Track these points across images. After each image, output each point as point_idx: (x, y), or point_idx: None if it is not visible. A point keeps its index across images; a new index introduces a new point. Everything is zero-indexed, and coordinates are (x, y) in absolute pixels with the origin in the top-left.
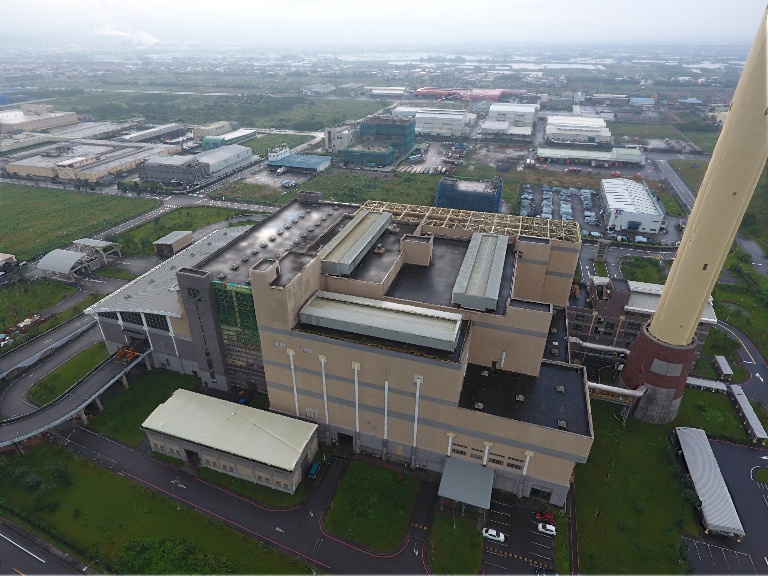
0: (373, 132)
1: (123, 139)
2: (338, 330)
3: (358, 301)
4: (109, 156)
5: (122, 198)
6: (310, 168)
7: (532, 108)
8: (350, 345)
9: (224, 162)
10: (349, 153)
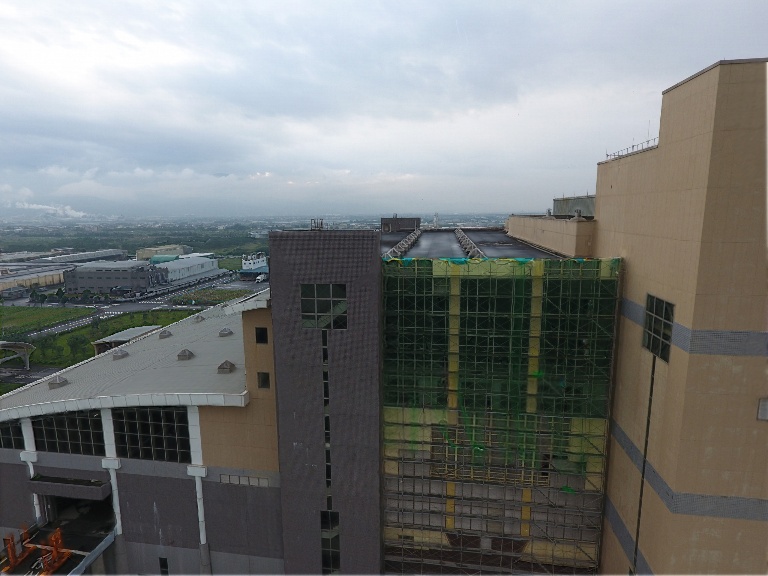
0: None
1: (43, 260)
2: None
3: None
4: (21, 272)
5: (36, 308)
6: None
7: None
8: None
9: (186, 270)
10: None
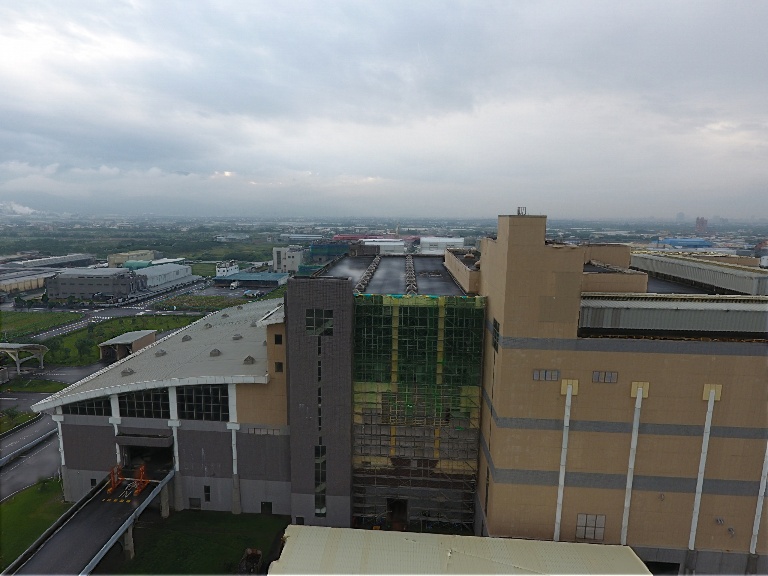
0: (326, 252)
1: (14, 264)
2: (656, 331)
3: (640, 294)
4: None
5: (24, 313)
6: (271, 281)
7: (460, 239)
8: (706, 347)
9: (163, 277)
10: (307, 269)
